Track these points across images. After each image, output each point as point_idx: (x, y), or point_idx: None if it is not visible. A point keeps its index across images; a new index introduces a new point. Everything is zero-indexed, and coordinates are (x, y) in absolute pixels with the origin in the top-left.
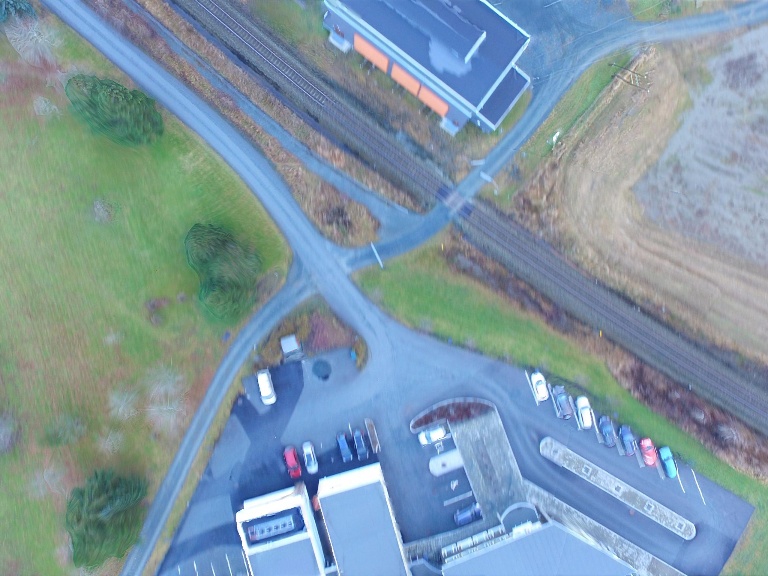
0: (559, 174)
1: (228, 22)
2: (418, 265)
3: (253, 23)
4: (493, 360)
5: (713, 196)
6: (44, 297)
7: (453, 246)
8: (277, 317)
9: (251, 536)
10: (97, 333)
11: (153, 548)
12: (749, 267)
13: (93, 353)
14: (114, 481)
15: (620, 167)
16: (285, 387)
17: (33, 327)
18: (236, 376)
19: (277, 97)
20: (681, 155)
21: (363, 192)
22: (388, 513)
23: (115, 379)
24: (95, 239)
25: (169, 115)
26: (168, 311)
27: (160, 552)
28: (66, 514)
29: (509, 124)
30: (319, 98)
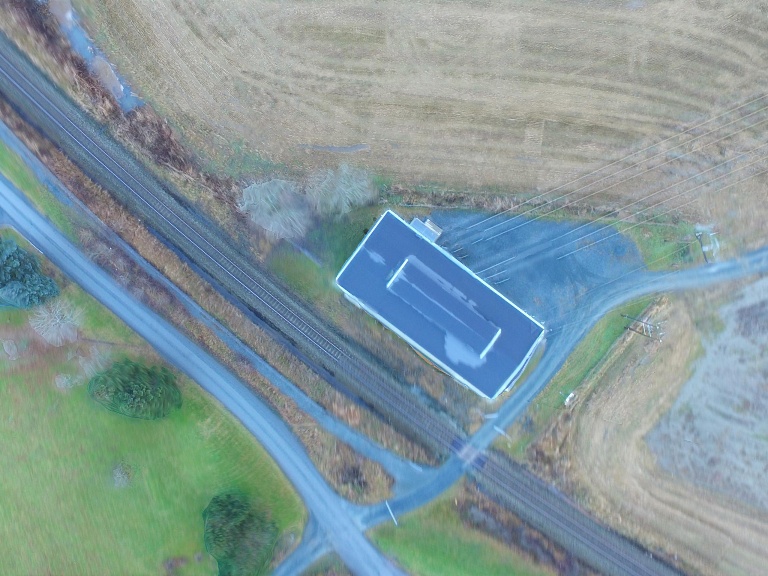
0: (572, 425)
1: (245, 280)
2: (432, 521)
3: (270, 280)
4: None
5: (725, 445)
6: (64, 557)
7: (467, 499)
8: (293, 575)
9: None
10: None
11: None
12: (761, 516)
13: None
14: None
15: (632, 416)
16: None
17: None
18: None
19: (293, 353)
20: (693, 403)
21: (378, 450)
22: None
23: None
24: (114, 499)
25: (187, 380)
26: (185, 570)
27: None
28: None
29: (522, 378)
30: (335, 353)
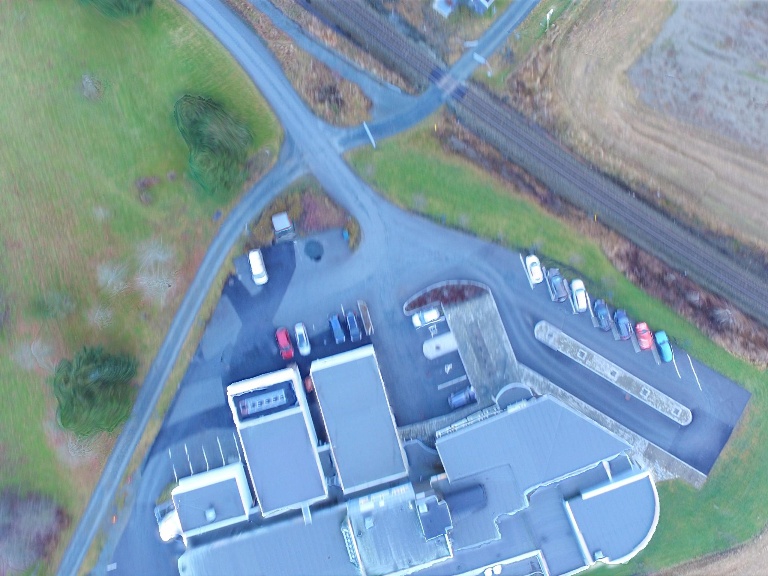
0: (553, 57)
1: None
2: (411, 145)
3: None
4: (487, 242)
5: (708, 80)
6: (32, 175)
7: (446, 128)
8: (269, 196)
9: (242, 410)
10: (86, 212)
11: (143, 430)
12: (744, 151)
13: (82, 232)
14: (103, 355)
15: (614, 51)
16: (277, 268)
17: (21, 206)
18: (227, 256)
19: None
20: (675, 39)
21: (355, 71)
22: (381, 387)
23: (104, 259)
24: (84, 117)
25: None
26: (158, 190)
27: (150, 434)
28: (54, 381)
29: (502, 5)
30: None
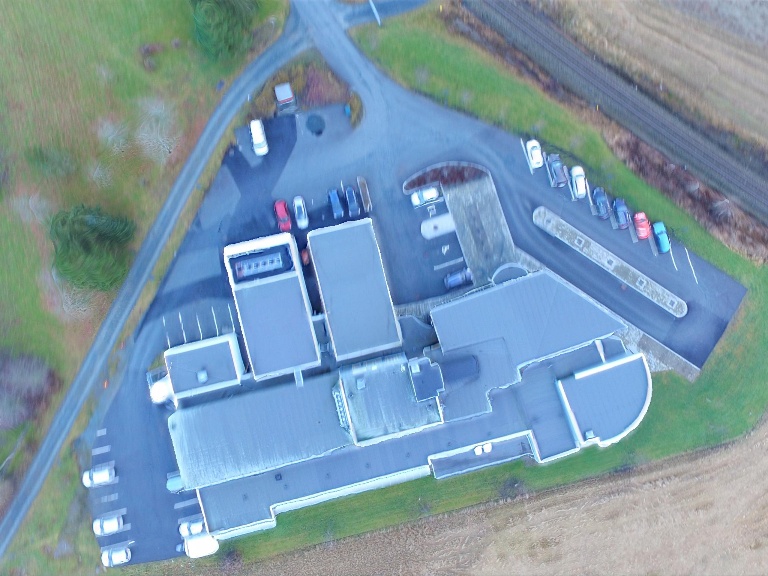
0: None
1: None
2: (416, 25)
3: None
4: (488, 125)
5: None
6: (37, 37)
7: (452, 11)
8: (272, 68)
9: (238, 272)
10: (89, 77)
11: (138, 296)
12: (748, 47)
13: (84, 96)
14: (101, 213)
15: None
16: (278, 140)
17: (24, 67)
18: (228, 126)
19: None
20: None
21: None
22: (378, 256)
23: (106, 124)
24: None
25: None
26: (162, 57)
27: (145, 301)
28: None
29: None
30: None
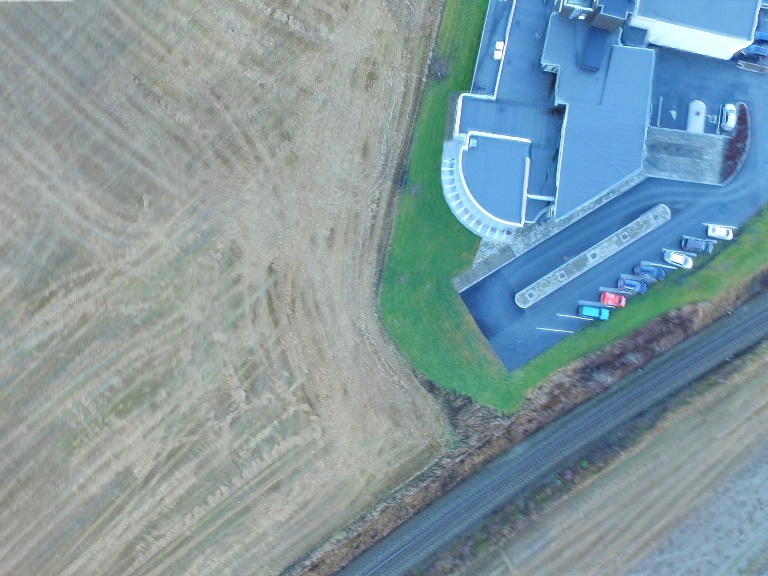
0: None
1: None
2: None
3: None
4: (762, 204)
5: None
6: None
7: None
8: None
9: None
10: None
11: None
12: (724, 475)
13: None
14: None
15: None
16: None
17: None
18: None
19: None
20: None
21: None
22: (719, 33)
23: None
24: None
25: None
26: None
27: None
28: None
29: None
30: None
